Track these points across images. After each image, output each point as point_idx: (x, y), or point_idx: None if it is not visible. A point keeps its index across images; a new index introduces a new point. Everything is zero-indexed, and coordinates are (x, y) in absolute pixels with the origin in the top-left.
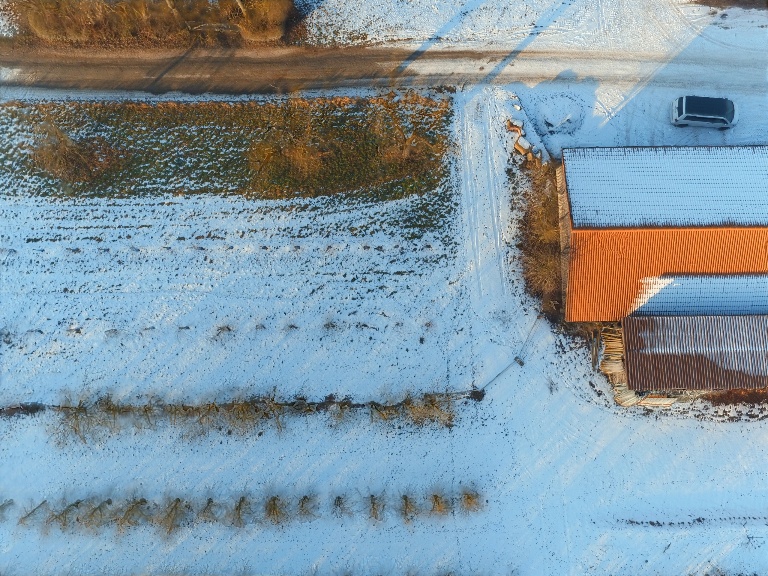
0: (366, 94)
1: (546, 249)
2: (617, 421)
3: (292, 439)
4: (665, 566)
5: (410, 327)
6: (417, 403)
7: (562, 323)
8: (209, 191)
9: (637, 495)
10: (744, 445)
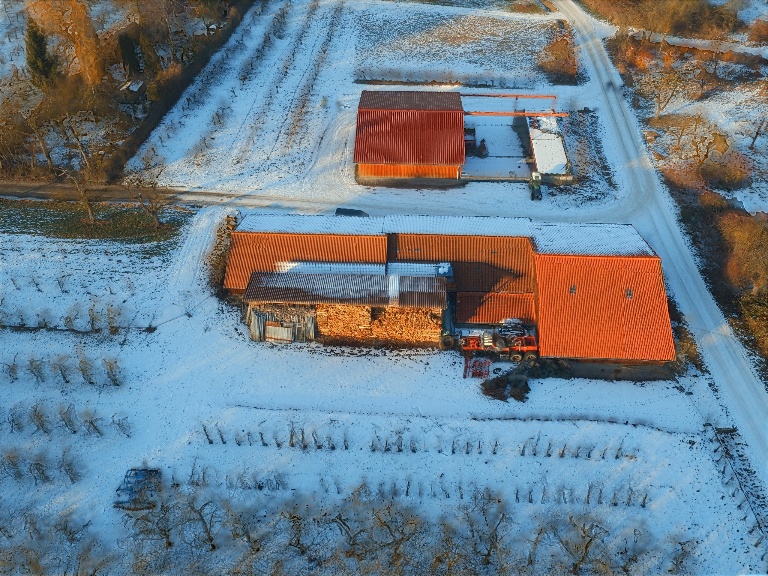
0: None
1: None
2: (248, 349)
3: (2, 344)
4: None
5: (120, 295)
6: (104, 331)
7: (227, 300)
8: (25, 233)
9: (251, 393)
10: (343, 370)
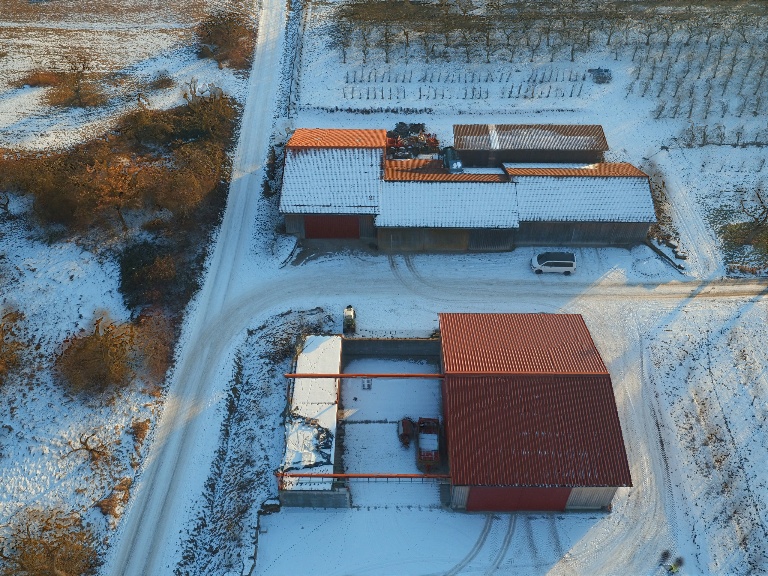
0: None
1: None
2: None
3: None
4: None
5: (712, 171)
6: (696, 145)
7: None
8: None
9: (570, 120)
10: None
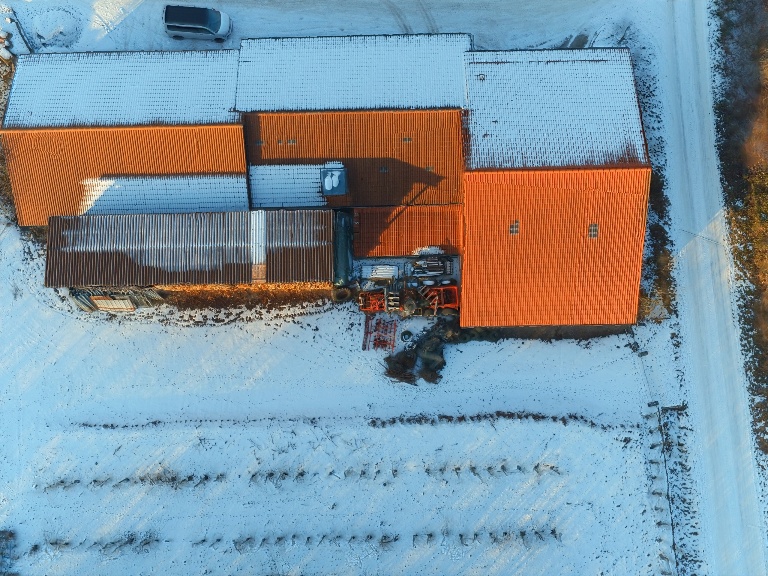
0: None
1: None
2: (79, 326)
3: None
4: (115, 468)
5: None
6: None
7: (32, 230)
8: None
9: (96, 399)
10: (208, 349)
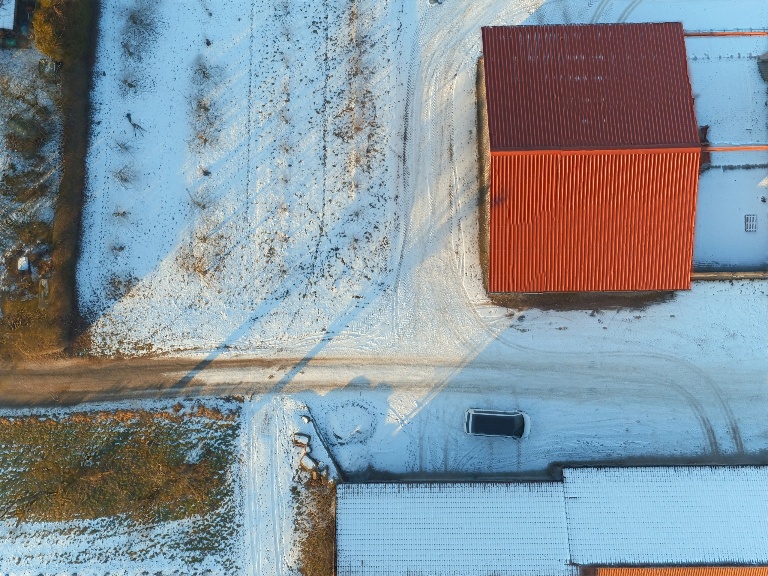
0: (151, 406)
1: (328, 574)
2: None
3: None
4: None
5: None
6: None
7: None
8: None
9: None
10: None
